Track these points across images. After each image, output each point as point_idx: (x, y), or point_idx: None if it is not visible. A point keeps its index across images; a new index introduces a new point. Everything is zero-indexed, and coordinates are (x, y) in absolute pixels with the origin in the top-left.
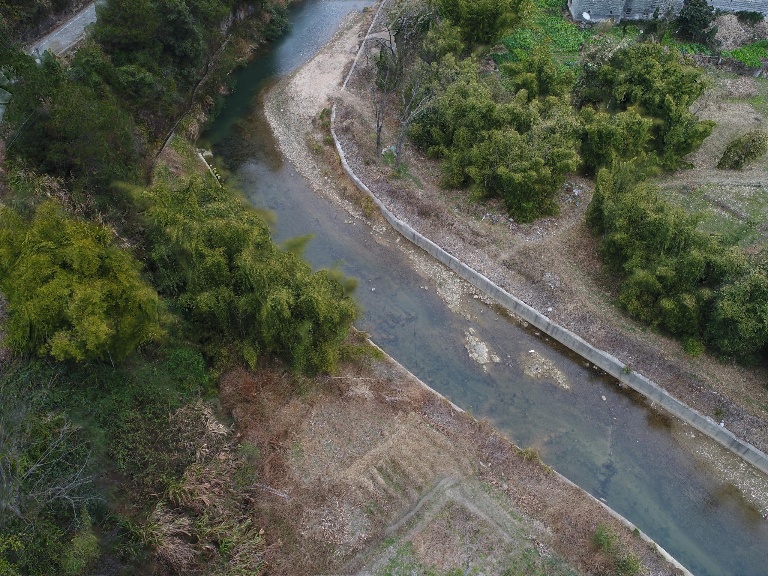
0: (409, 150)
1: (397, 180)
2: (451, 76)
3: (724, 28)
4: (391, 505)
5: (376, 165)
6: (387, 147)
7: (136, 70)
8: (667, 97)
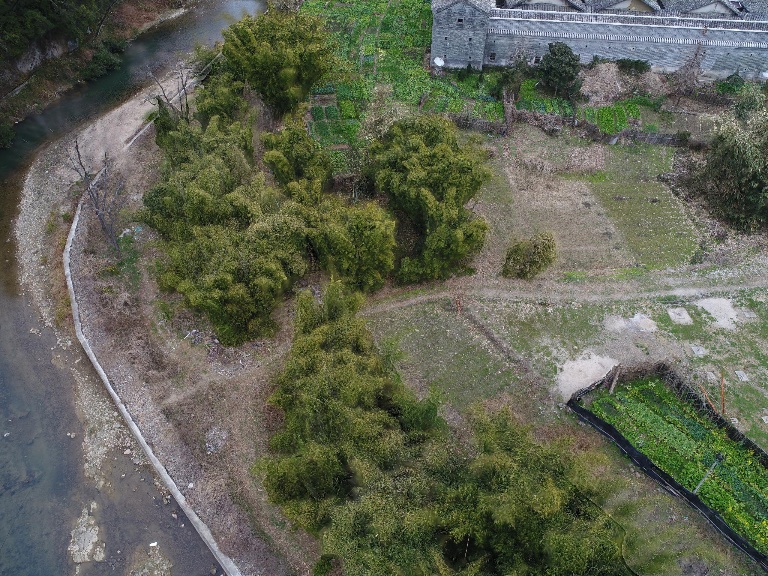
0: (155, 233)
1: (108, 278)
2: (209, 145)
3: (599, 79)
4: None
5: (96, 255)
6: (131, 228)
7: None
8: (421, 192)
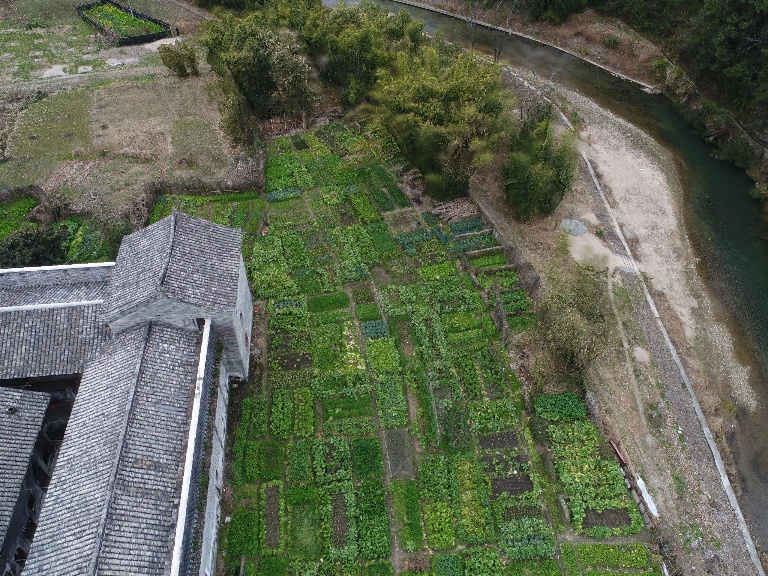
0: None
1: None
2: None
3: None
4: None
5: None
6: None
7: (713, 2)
8: None
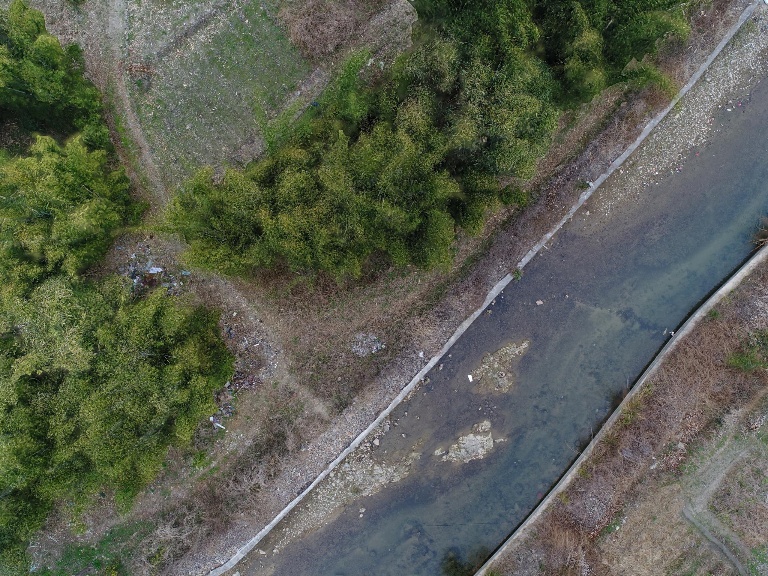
0: None
1: (130, 570)
2: None
3: None
4: (716, 570)
5: None
6: None
7: None
8: None
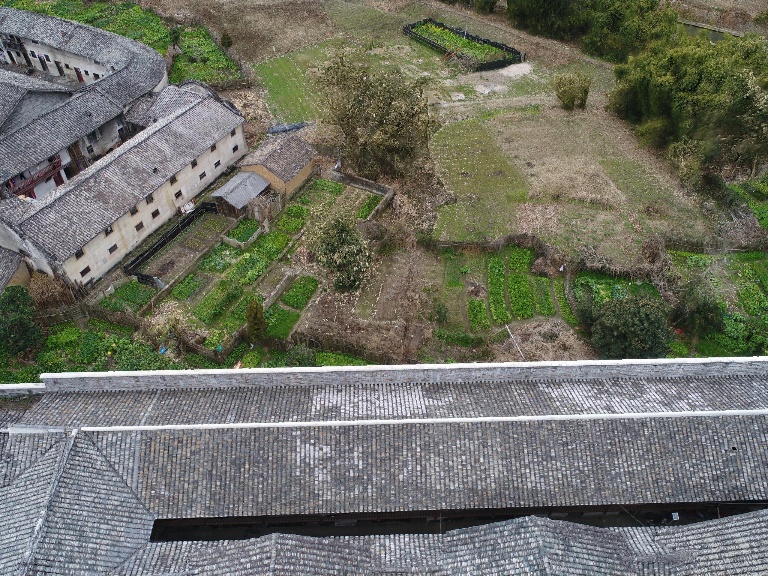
0: None
1: None
2: None
3: None
4: None
5: None
6: None
7: None
8: None
